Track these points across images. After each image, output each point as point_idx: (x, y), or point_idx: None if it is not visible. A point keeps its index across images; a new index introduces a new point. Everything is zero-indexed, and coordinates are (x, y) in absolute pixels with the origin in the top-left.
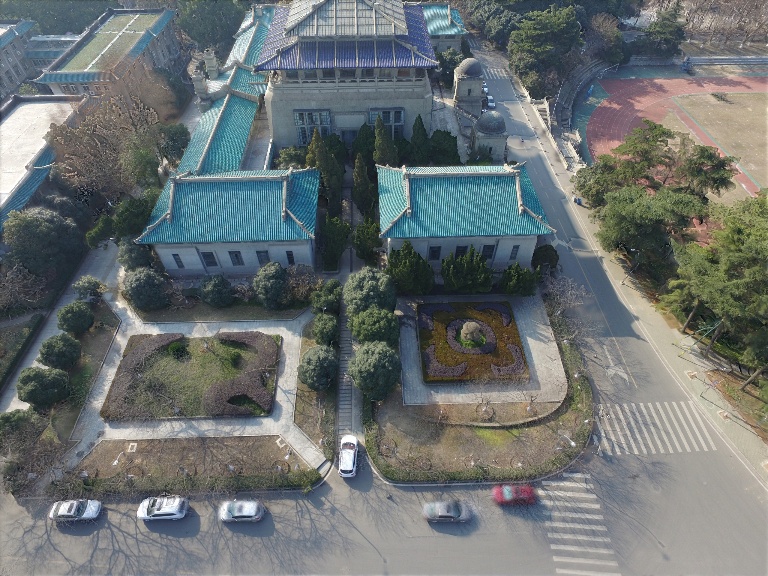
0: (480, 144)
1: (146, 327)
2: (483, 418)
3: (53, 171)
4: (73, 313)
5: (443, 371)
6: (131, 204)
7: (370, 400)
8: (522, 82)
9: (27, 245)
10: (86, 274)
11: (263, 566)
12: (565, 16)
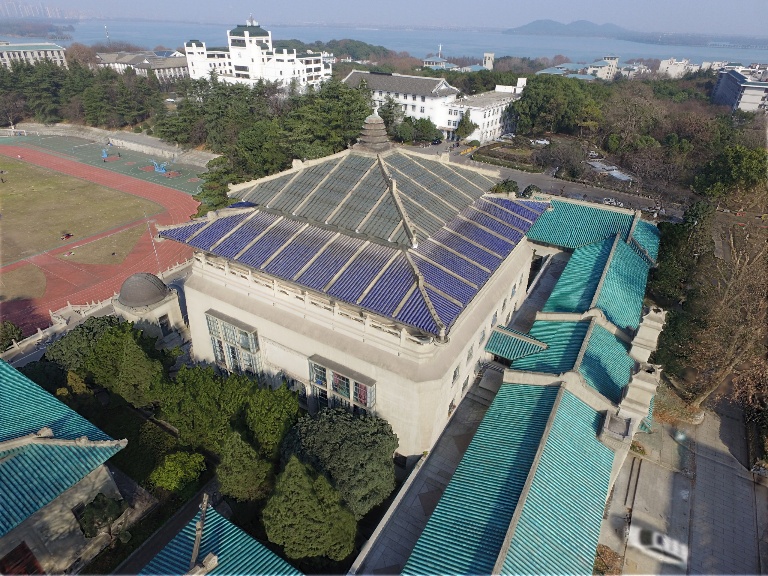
0: None
1: None
2: None
3: None
4: None
5: None
6: (677, 227)
7: None
8: None
9: None
10: None
11: (568, 192)
12: None
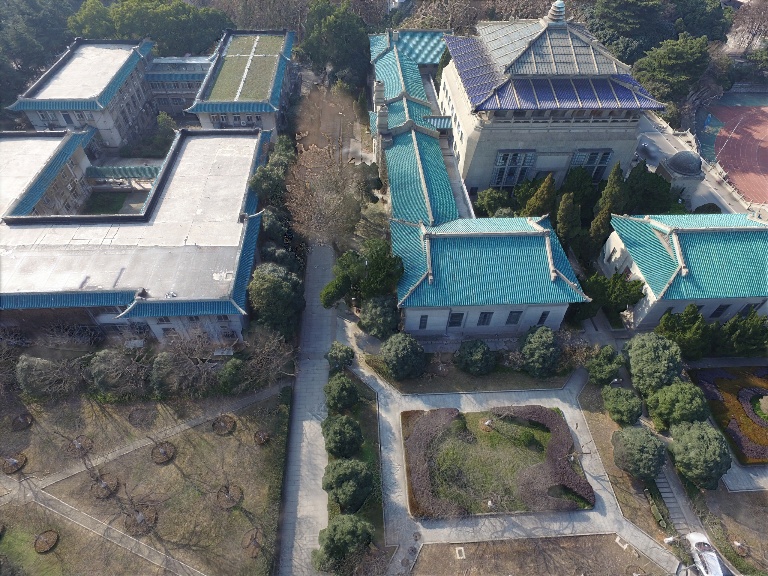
0: (675, 185)
1: (407, 400)
2: None
3: (270, 220)
4: (345, 390)
5: (760, 451)
6: (383, 262)
7: (696, 488)
8: (657, 112)
9: (274, 309)
10: (311, 335)
11: None
12: (698, 45)
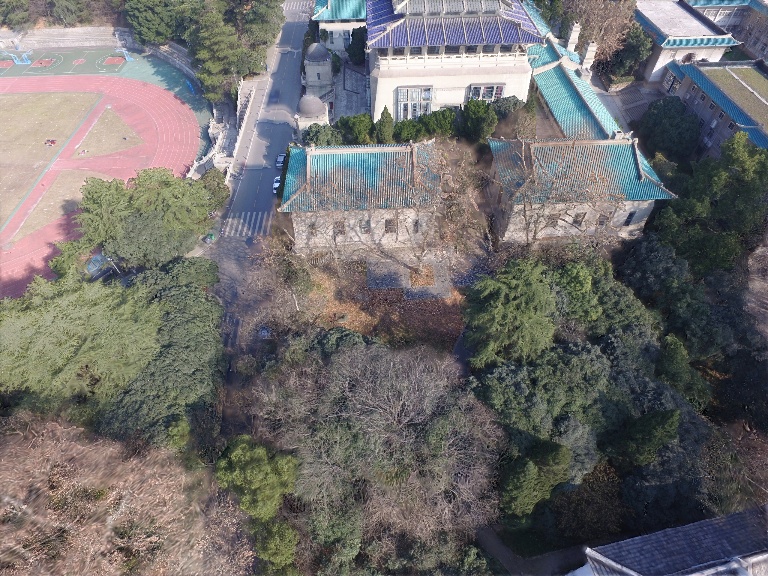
0: None
1: None
2: None
3: (608, 0)
4: None
5: None
6: None
7: None
8: None
9: None
10: None
11: None
12: (107, 183)
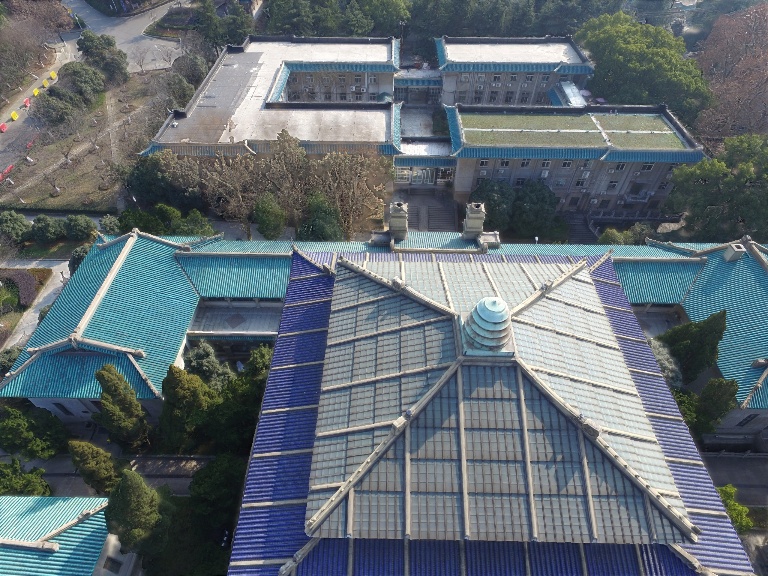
0: None
1: None
2: None
3: None
4: None
5: None
6: None
7: None
8: None
9: None
10: None
11: None
12: None
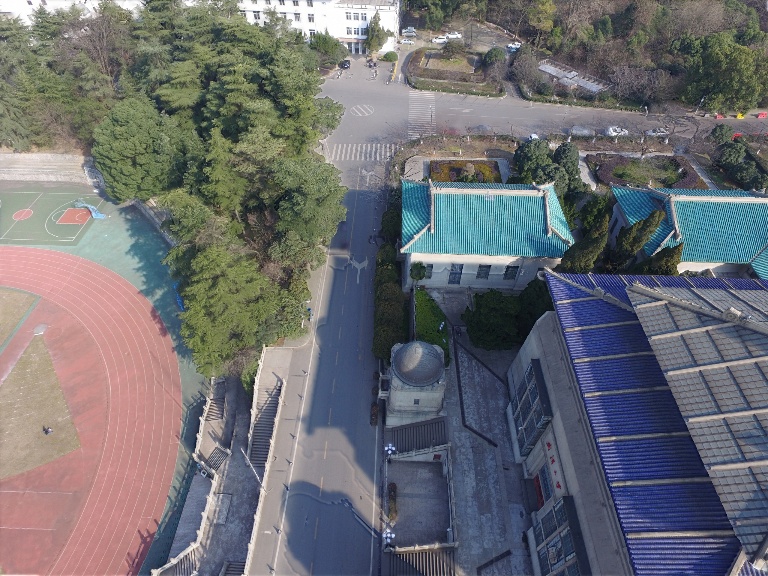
0: None
1: None
2: (461, 152)
3: None
4: None
5: (486, 162)
6: None
7: None
8: None
9: None
10: None
11: None
12: None
